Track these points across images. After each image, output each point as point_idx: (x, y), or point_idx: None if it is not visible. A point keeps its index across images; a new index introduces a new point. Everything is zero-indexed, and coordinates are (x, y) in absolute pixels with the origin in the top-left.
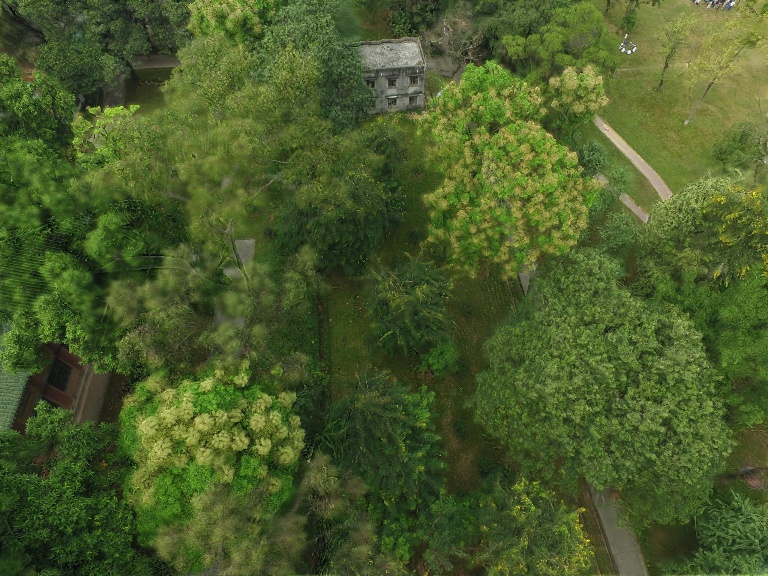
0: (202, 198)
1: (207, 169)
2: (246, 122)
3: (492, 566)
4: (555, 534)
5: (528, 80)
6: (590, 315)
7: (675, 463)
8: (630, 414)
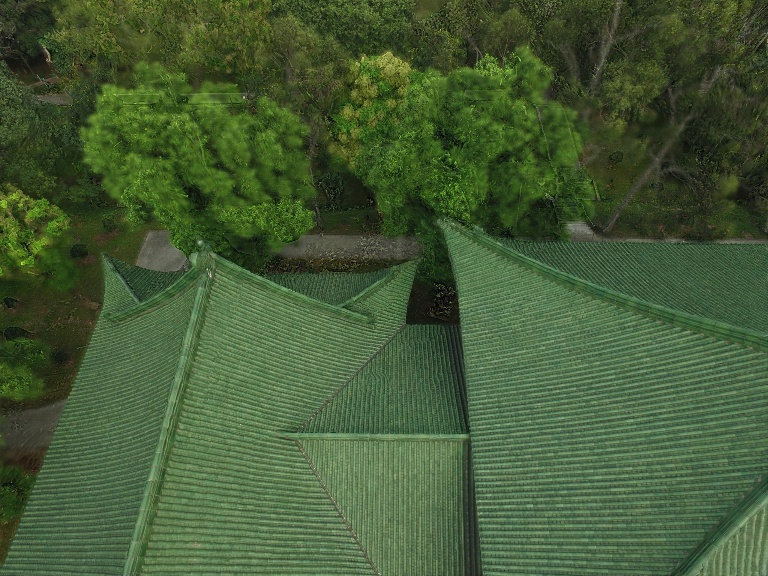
0: (63, 280)
1: (14, 280)
2: (1, 180)
3: (449, 68)
4: (437, 38)
5: (74, 6)
6: (323, 1)
7: (407, 2)
8: (383, 2)
